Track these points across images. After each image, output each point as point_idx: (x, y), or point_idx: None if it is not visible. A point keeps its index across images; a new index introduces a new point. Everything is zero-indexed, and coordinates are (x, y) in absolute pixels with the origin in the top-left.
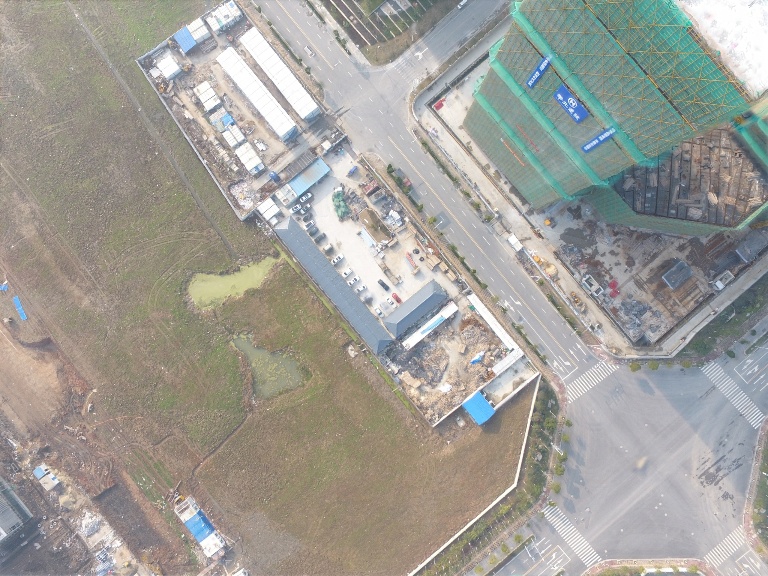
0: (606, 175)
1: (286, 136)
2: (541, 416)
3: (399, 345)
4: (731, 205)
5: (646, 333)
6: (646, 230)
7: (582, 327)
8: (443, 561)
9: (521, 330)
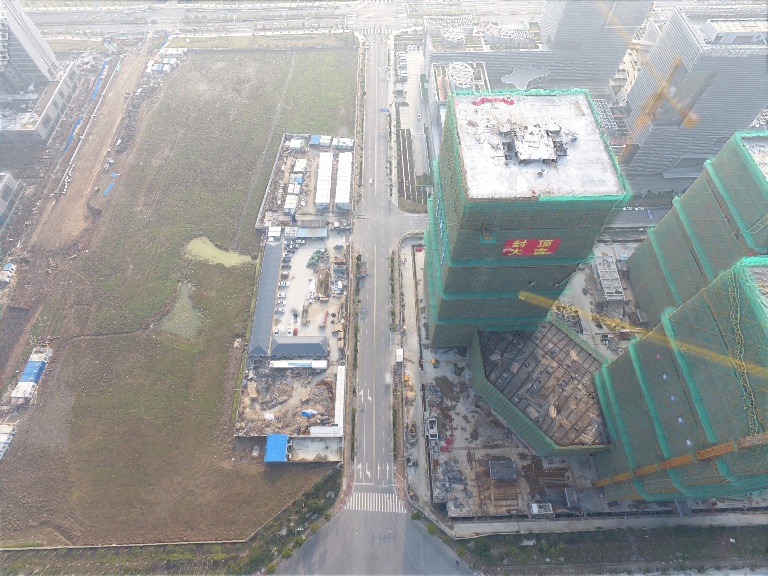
0: (444, 285)
1: (320, 206)
2: (313, 494)
3: (268, 361)
4: (565, 427)
5: (449, 502)
6: (503, 421)
7: (401, 454)
8: (133, 558)
9: (356, 419)
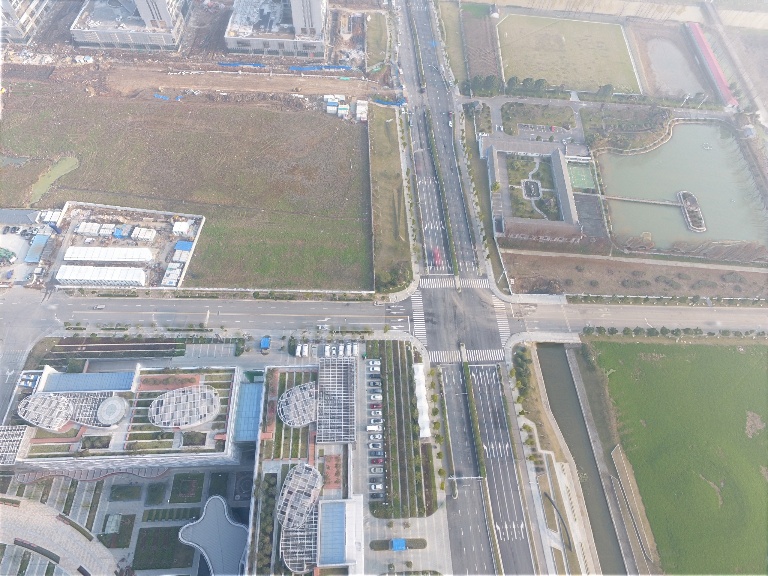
0: None
1: None
2: None
3: None
4: None
5: None
6: None
7: None
8: None
9: None
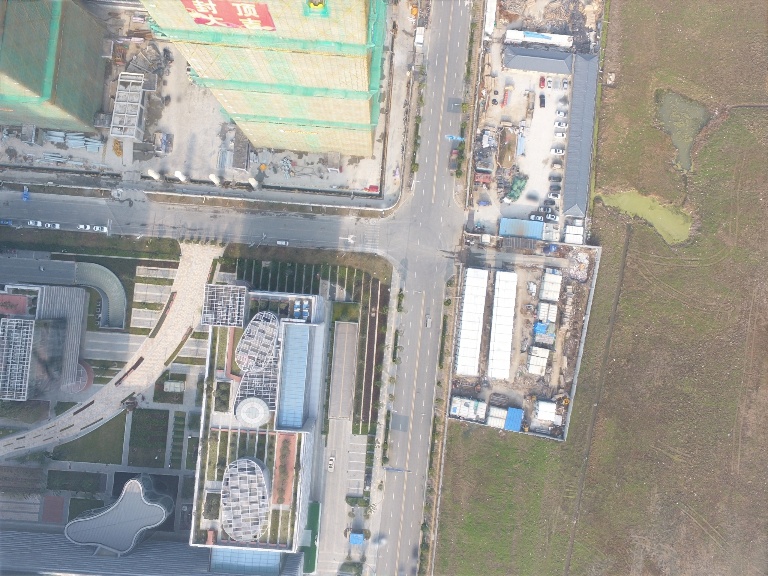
0: None
1: None
2: None
3: None
4: None
5: None
6: None
7: None
8: None
9: None
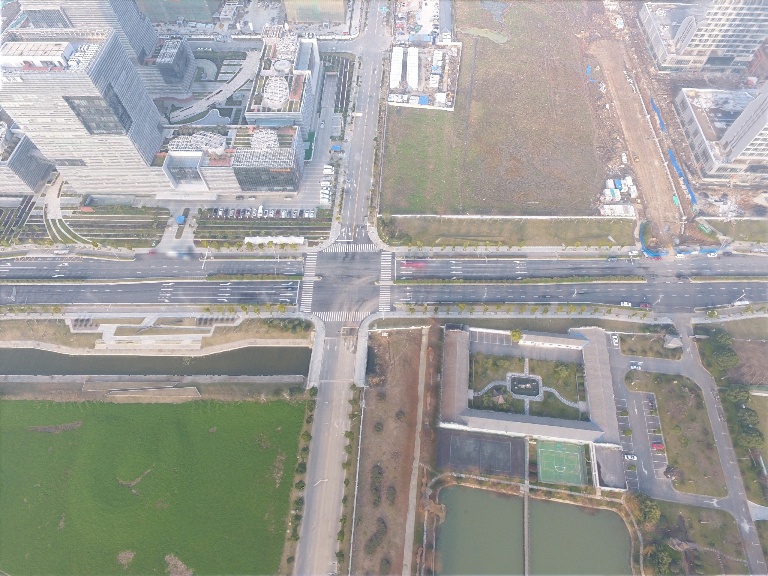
0: None
1: None
2: None
3: None
4: None
5: None
6: None
7: None
8: None
9: None
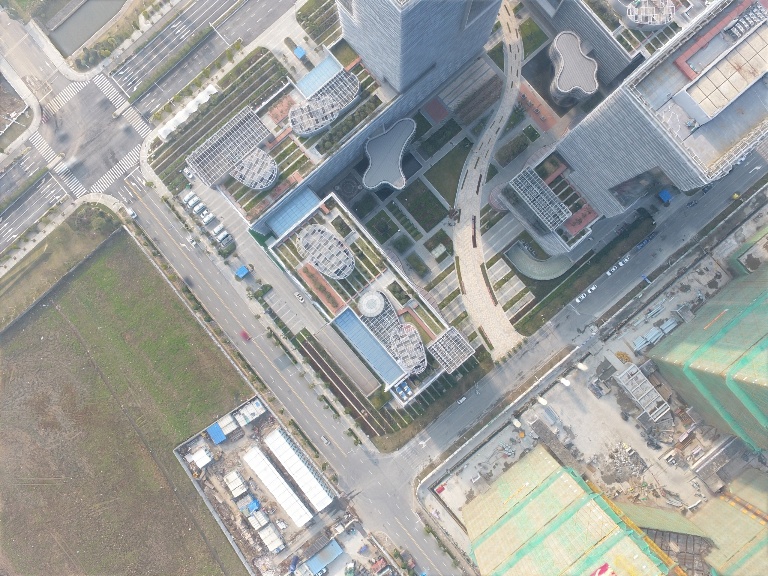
0: None
1: None
2: None
3: None
4: None
5: None
6: None
7: None
8: None
9: None
